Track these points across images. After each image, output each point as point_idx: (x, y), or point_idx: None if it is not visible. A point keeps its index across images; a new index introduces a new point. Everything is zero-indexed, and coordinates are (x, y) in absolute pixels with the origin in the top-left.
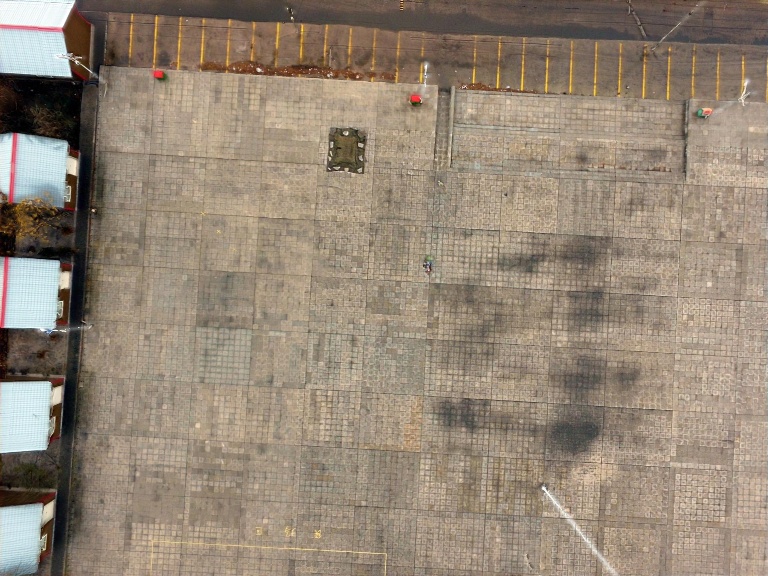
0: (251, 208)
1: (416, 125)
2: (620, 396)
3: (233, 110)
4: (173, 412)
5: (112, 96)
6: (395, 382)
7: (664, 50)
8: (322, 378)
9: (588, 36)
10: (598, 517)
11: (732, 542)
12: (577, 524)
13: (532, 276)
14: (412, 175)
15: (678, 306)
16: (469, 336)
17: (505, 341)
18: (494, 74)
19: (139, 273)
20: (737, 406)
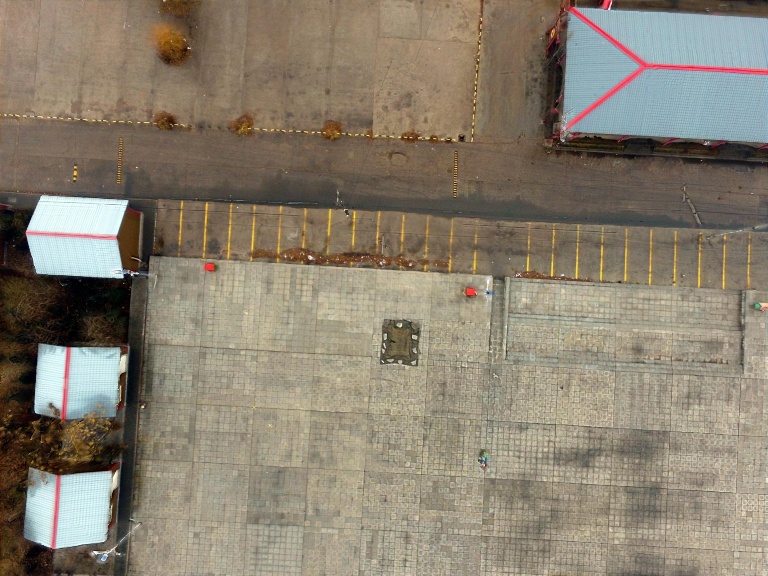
0: (303, 401)
1: (471, 317)
2: None
3: (285, 301)
4: None
5: (162, 287)
6: None
7: (719, 238)
8: None
9: (643, 224)
10: None
11: None
12: None
13: (589, 471)
14: (467, 368)
15: (737, 502)
16: (525, 533)
17: (562, 538)
18: (548, 262)
19: (189, 469)
20: None
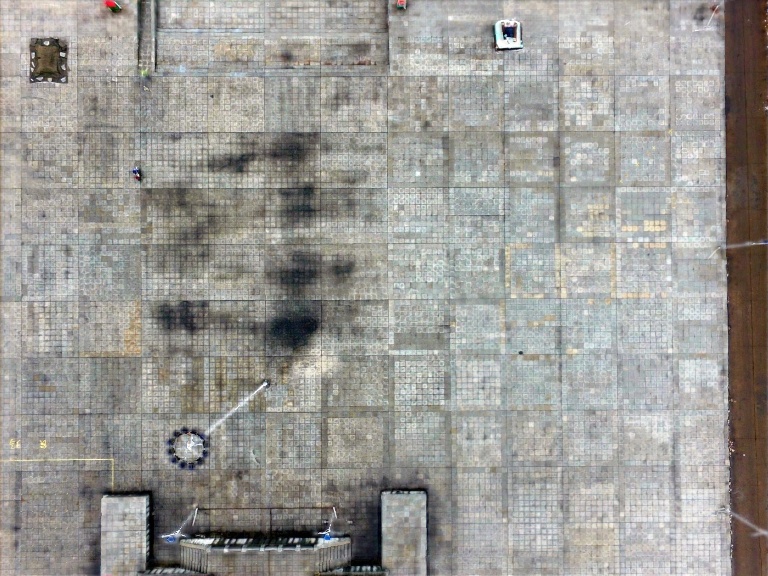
0: None
1: (117, 31)
2: (336, 289)
3: None
4: None
5: None
6: (112, 289)
7: None
8: (38, 290)
9: None
10: (321, 409)
11: (452, 424)
12: (300, 417)
13: (243, 176)
14: (117, 82)
15: (388, 197)
16: (184, 239)
17: (220, 242)
18: None
19: None
20: (451, 291)
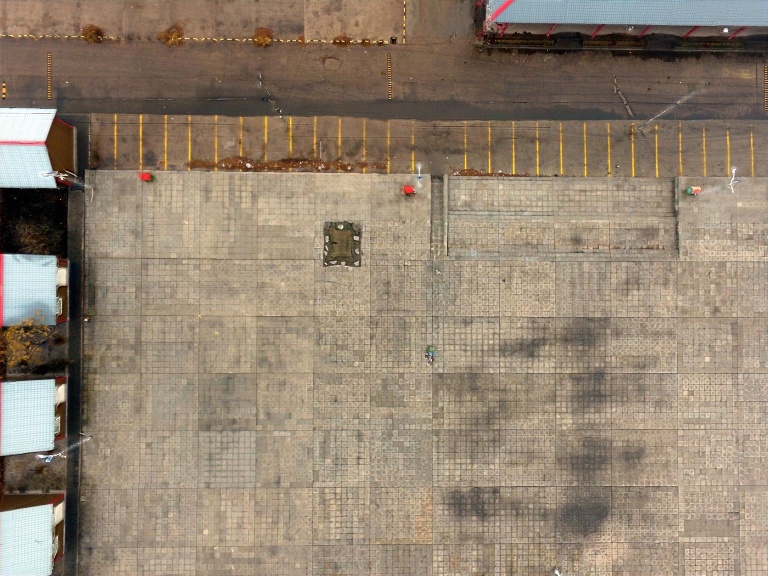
0: (248, 307)
1: (411, 215)
2: (626, 475)
3: (225, 209)
4: (179, 520)
5: (99, 201)
6: (403, 475)
7: (651, 128)
8: (330, 475)
9: (576, 117)
10: None
11: None
12: None
13: (534, 360)
14: (409, 266)
15: (678, 382)
16: (475, 424)
17: (511, 427)
18: (485, 159)
19: (137, 380)
20: (740, 478)
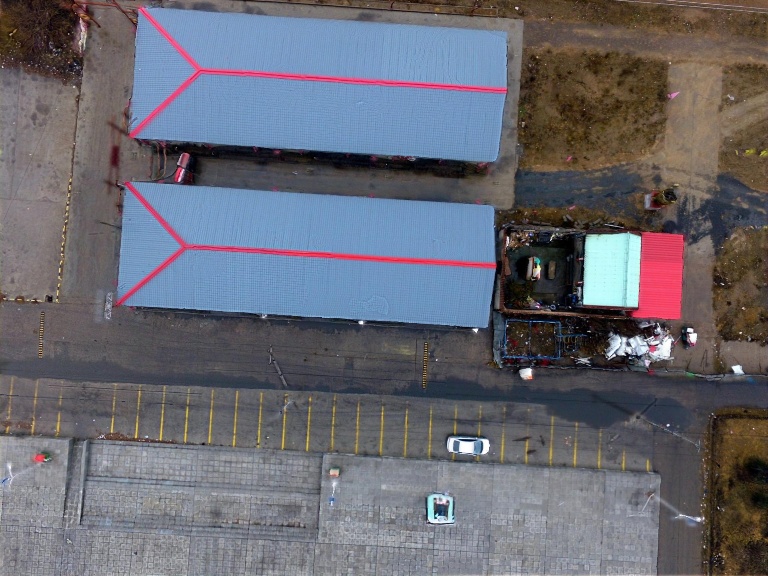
0: None
1: (45, 481)
2: None
3: None
4: None
5: None
6: None
7: (305, 400)
8: None
9: (229, 385)
10: None
11: None
12: None
13: None
14: (40, 533)
15: None
16: None
17: None
18: (133, 423)
19: None
20: None
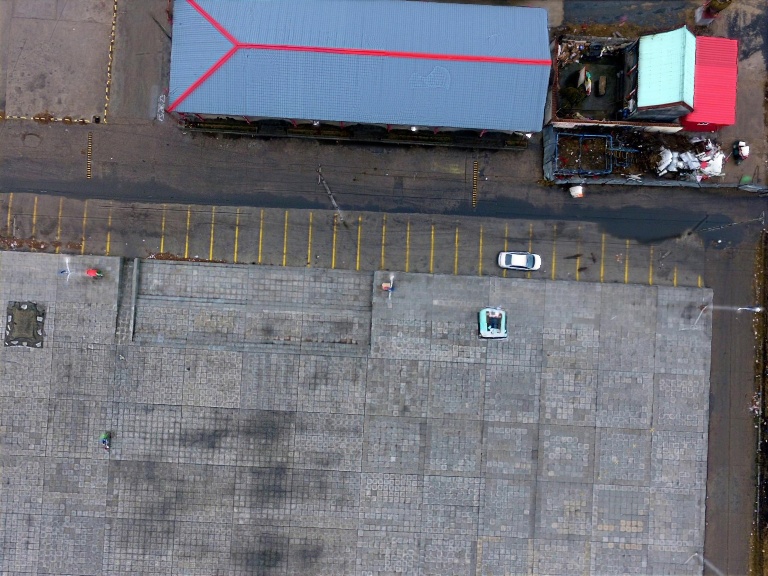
0: None
1: (97, 298)
2: (302, 574)
3: None
4: None
5: None
6: (72, 562)
7: (354, 219)
8: None
9: (278, 205)
10: None
11: None
12: None
13: (214, 452)
14: (93, 349)
15: (361, 481)
16: (149, 514)
17: (186, 518)
18: (183, 243)
19: None
20: None
